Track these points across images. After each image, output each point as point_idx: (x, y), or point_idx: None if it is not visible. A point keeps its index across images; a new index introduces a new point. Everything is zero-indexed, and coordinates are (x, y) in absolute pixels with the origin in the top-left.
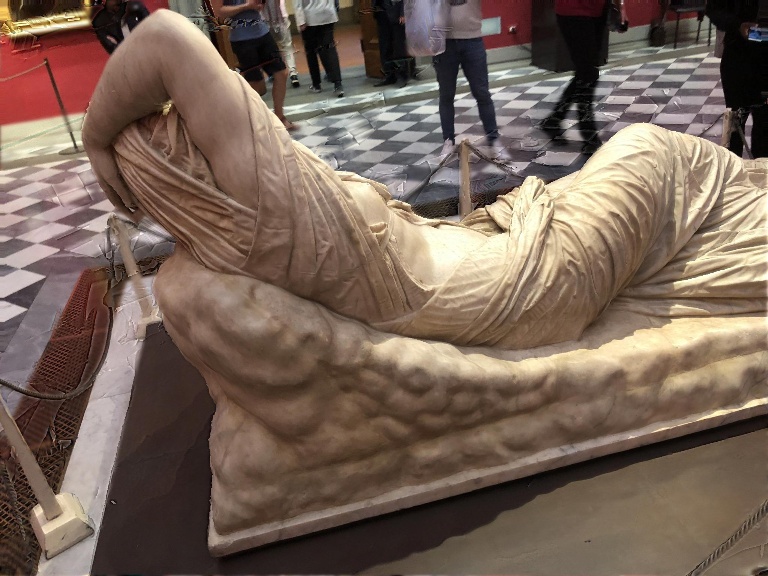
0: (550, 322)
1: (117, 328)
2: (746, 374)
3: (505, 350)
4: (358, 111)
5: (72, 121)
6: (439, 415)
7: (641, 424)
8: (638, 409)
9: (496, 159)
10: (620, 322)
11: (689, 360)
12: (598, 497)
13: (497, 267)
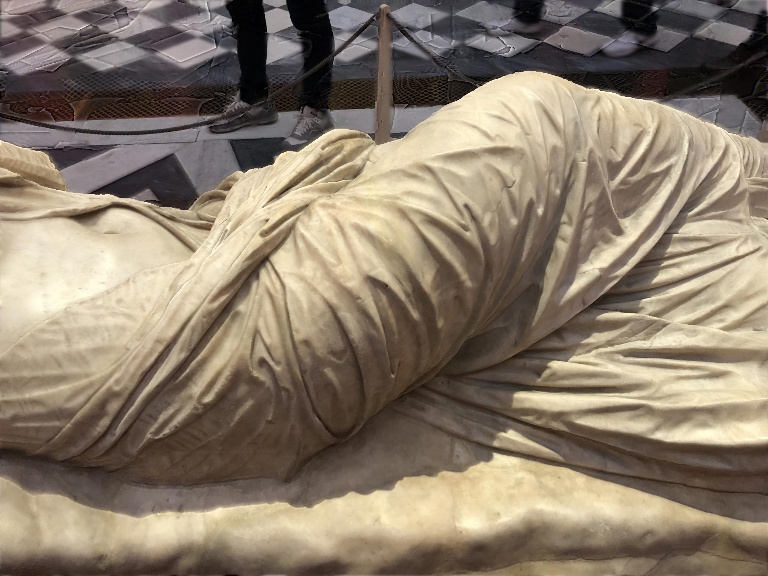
0: (220, 454)
1: None
2: None
3: (132, 484)
4: None
5: None
6: None
7: None
8: None
9: (500, 28)
10: (390, 448)
11: (479, 555)
12: None
13: (109, 349)
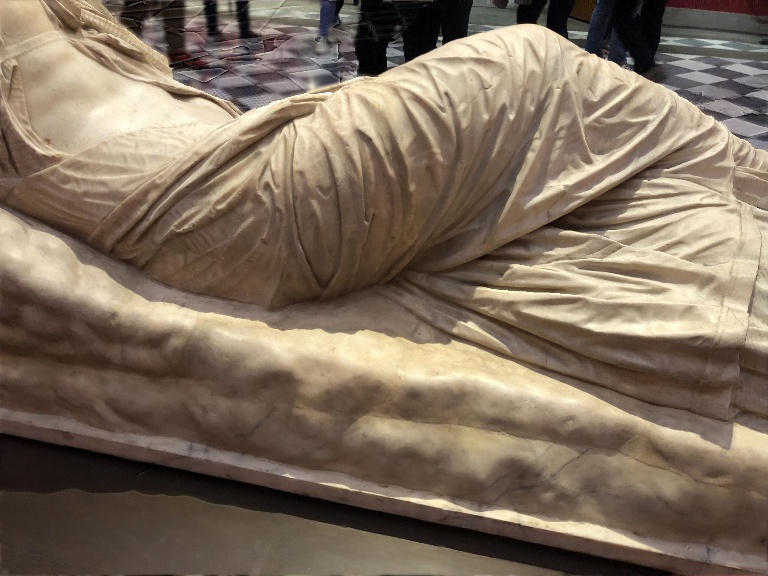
0: (222, 265)
1: None
2: (504, 465)
3: (154, 281)
4: None
5: None
6: (8, 325)
7: (314, 464)
8: (306, 440)
9: None
10: (363, 312)
11: (412, 404)
12: (192, 531)
13: (162, 158)
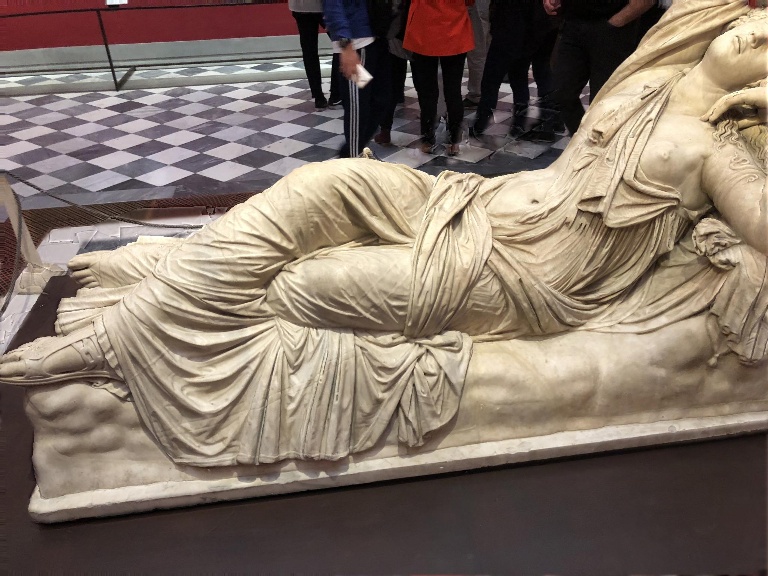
0: None
1: None
2: None
3: None
4: None
5: None
6: None
7: None
8: None
9: None
10: None
11: None
12: None
13: None
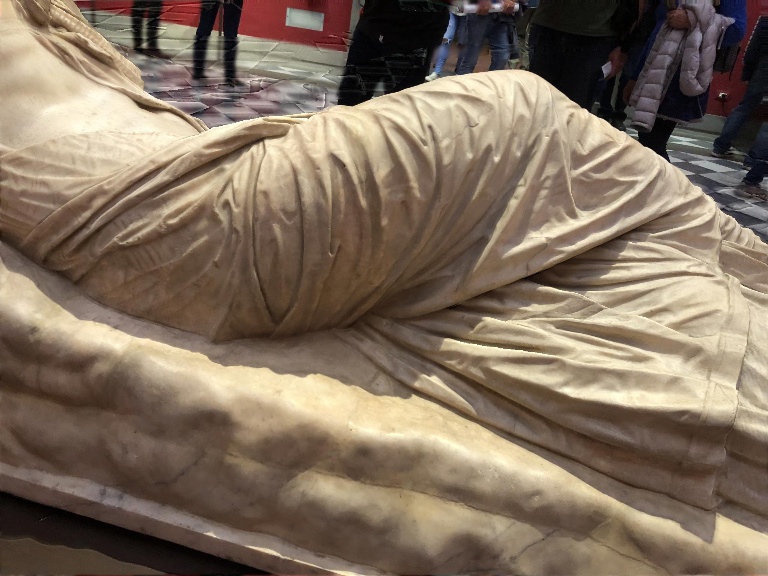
0: (166, 287)
1: None
2: (460, 542)
3: (88, 298)
4: (383, 56)
5: None
6: None
7: (244, 524)
8: (237, 494)
9: None
10: (318, 354)
11: (362, 462)
12: None
13: (115, 163)
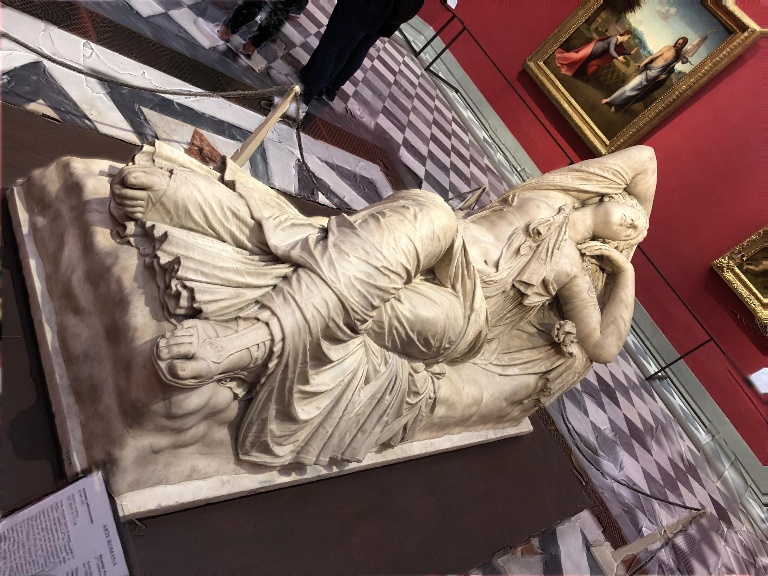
0: None
1: (601, 480)
2: None
3: None
4: None
5: (766, 420)
6: None
7: None
8: None
9: None
10: None
11: None
12: None
13: None
